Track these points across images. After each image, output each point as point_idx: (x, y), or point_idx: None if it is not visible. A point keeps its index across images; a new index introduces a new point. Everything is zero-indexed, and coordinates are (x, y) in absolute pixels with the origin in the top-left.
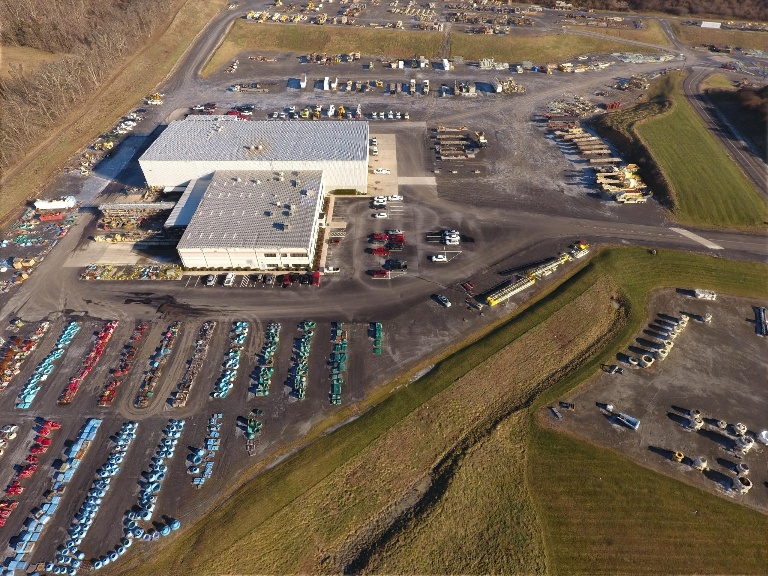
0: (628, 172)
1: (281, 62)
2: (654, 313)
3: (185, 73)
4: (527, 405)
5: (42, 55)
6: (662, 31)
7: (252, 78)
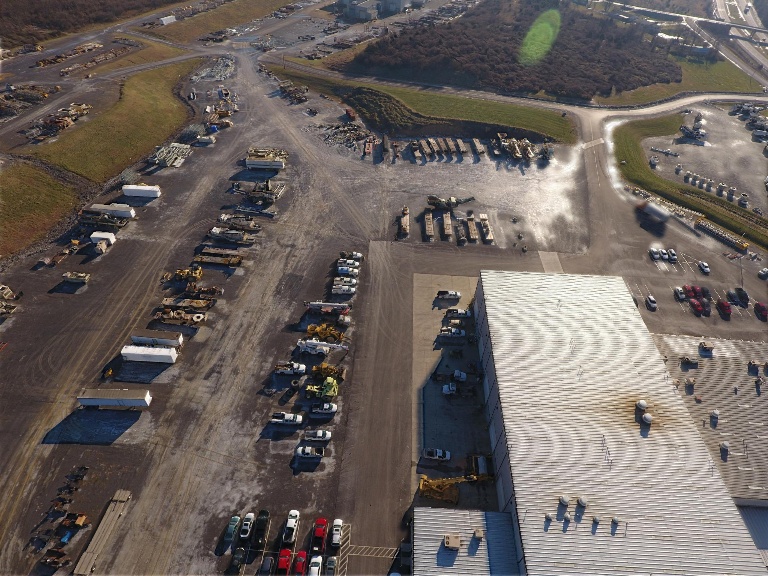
0: (514, 139)
1: None
2: (686, 183)
3: None
4: None
5: None
6: (151, 41)
7: None
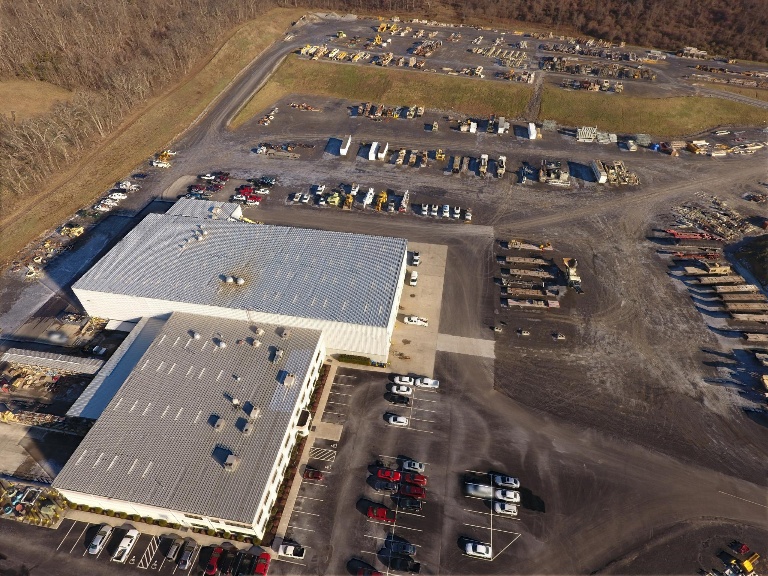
0: None
1: (327, 113)
2: None
3: (212, 122)
4: None
5: (58, 93)
6: None
7: (286, 135)
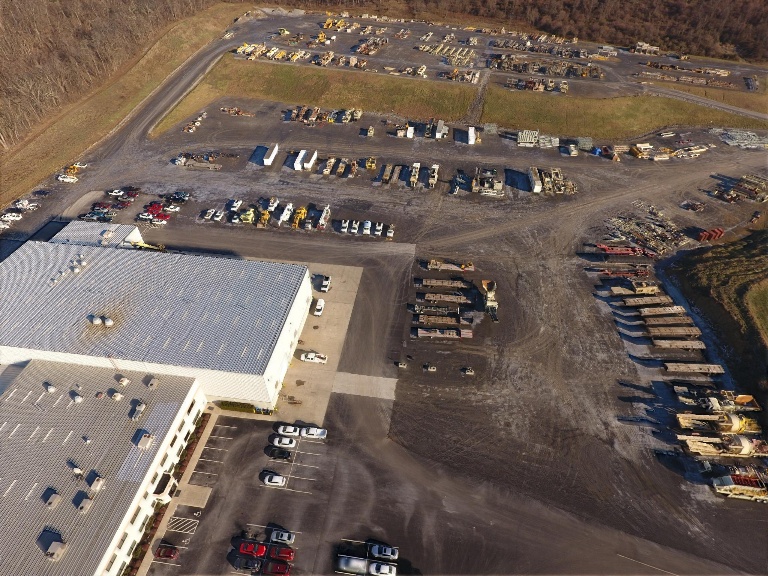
0: (738, 418)
1: (258, 118)
2: None
3: (133, 130)
4: None
5: None
6: None
7: (211, 143)
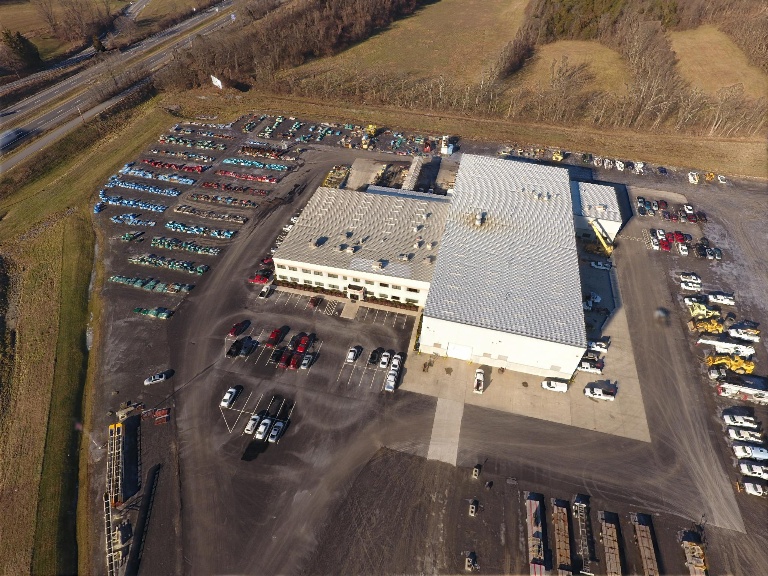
0: None
1: None
2: None
3: None
4: None
5: (761, 92)
6: None
7: None
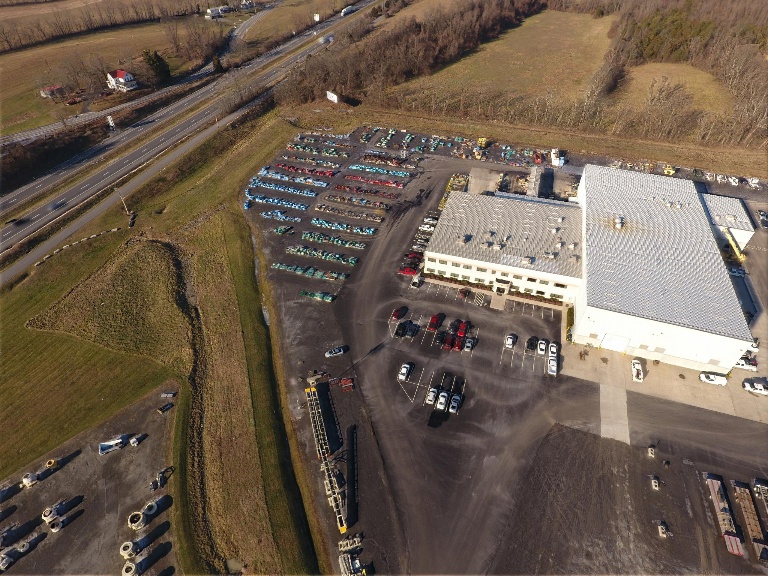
0: None
1: None
2: None
3: None
4: (191, 377)
5: None
6: None
7: None
